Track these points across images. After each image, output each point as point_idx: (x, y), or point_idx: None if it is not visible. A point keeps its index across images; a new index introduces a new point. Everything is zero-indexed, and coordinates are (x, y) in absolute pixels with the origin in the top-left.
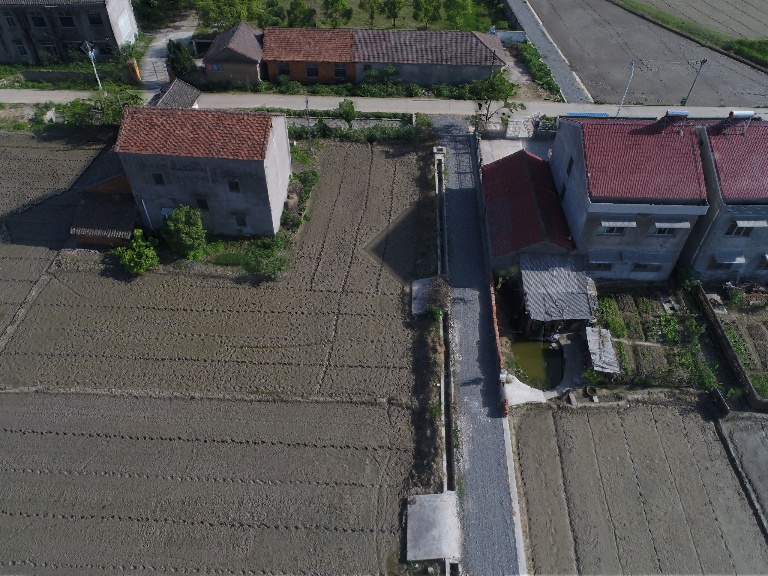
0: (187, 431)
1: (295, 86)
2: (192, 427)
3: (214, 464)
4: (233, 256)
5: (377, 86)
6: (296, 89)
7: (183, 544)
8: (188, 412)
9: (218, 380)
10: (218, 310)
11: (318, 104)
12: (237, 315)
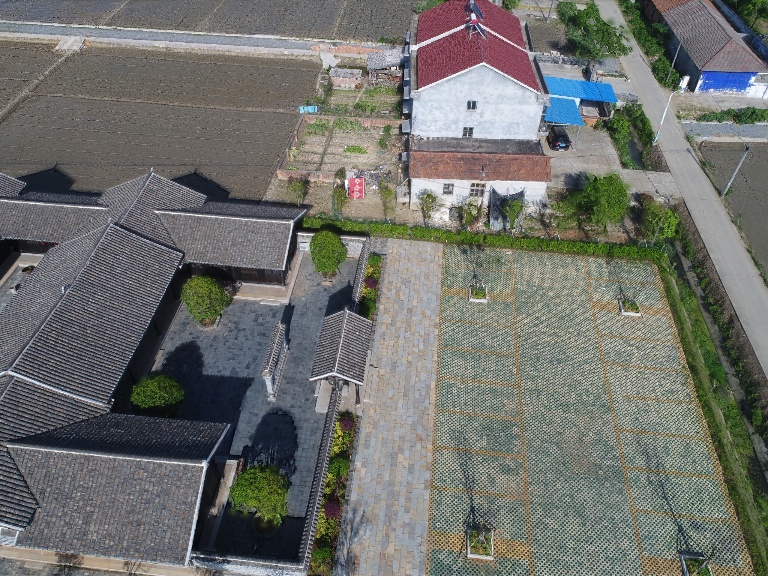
0: (328, 2)
1: (632, 13)
2: (330, 3)
3: (312, 7)
4: (432, 3)
5: (648, 37)
6: (630, 15)
7: (281, 4)
8: (337, 2)
9: (353, 6)
10: (396, 5)
11: (613, 23)
12: (393, 8)
